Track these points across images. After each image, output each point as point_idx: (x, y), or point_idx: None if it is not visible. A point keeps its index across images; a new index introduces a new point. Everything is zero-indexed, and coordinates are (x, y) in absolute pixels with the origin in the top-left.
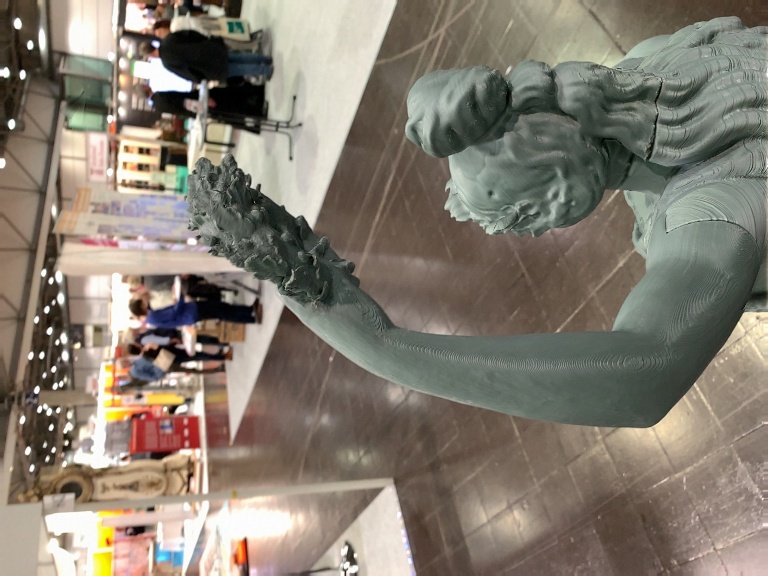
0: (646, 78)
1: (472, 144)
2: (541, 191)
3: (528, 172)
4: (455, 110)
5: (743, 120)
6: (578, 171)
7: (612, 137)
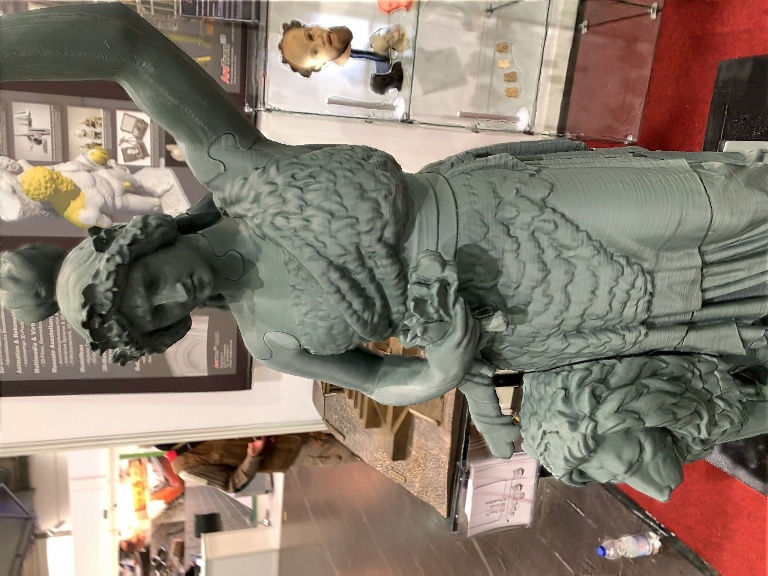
0: None
1: (58, 267)
2: None
3: None
4: None
5: None
6: None
7: None
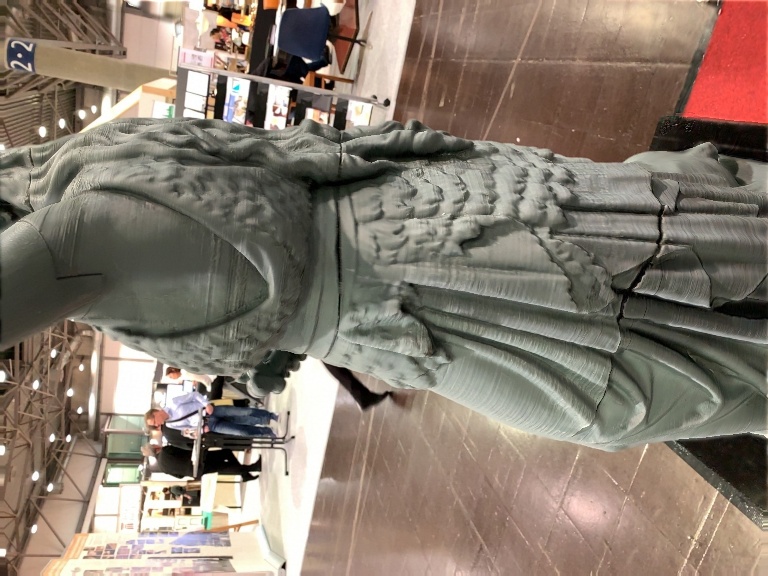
0: (21, 148)
1: None
2: None
3: None
4: None
5: (70, 154)
6: None
7: None
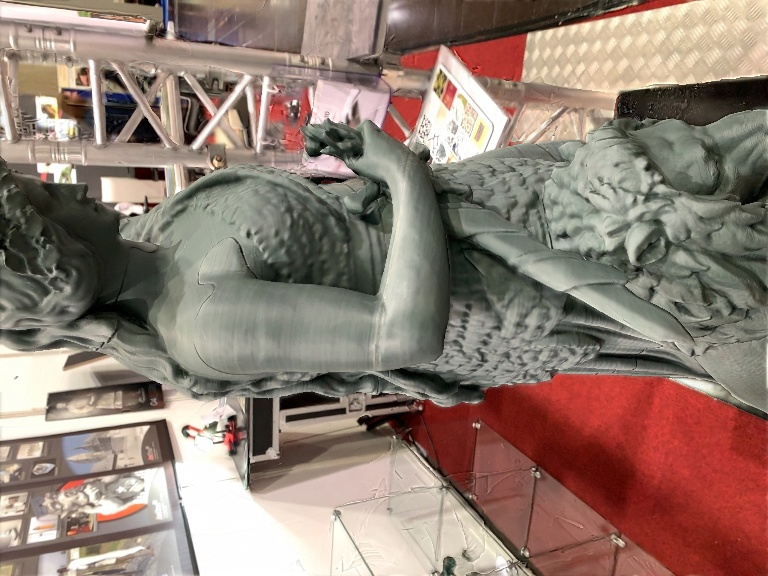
0: None
1: None
2: None
3: None
4: None
5: None
6: None
7: None
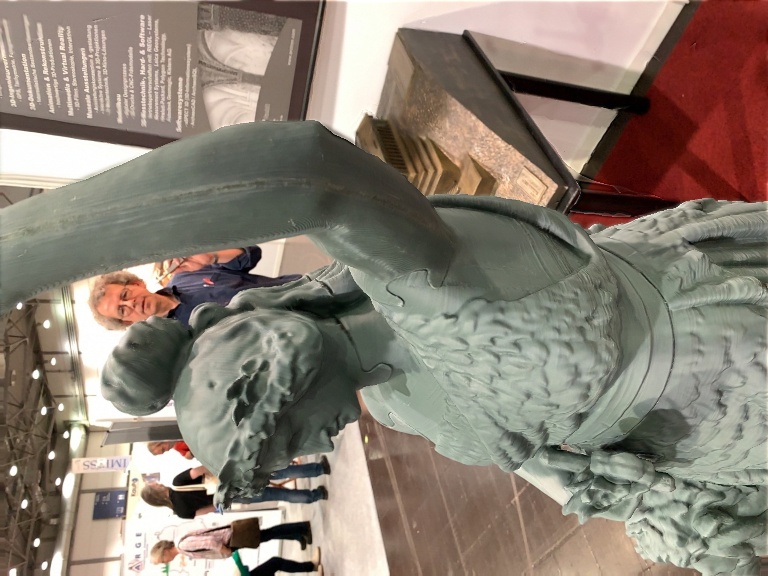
0: None
1: (176, 373)
2: (255, 349)
3: (231, 343)
4: (129, 331)
5: None
6: (274, 318)
7: (291, 300)
